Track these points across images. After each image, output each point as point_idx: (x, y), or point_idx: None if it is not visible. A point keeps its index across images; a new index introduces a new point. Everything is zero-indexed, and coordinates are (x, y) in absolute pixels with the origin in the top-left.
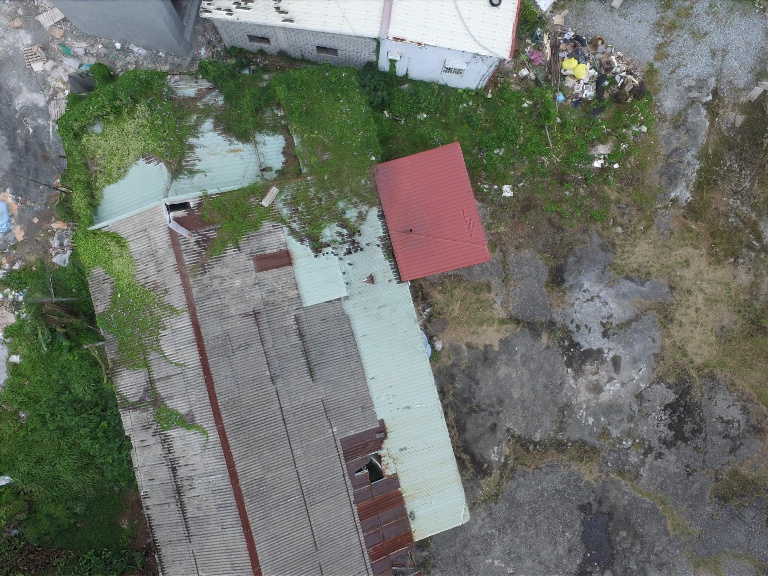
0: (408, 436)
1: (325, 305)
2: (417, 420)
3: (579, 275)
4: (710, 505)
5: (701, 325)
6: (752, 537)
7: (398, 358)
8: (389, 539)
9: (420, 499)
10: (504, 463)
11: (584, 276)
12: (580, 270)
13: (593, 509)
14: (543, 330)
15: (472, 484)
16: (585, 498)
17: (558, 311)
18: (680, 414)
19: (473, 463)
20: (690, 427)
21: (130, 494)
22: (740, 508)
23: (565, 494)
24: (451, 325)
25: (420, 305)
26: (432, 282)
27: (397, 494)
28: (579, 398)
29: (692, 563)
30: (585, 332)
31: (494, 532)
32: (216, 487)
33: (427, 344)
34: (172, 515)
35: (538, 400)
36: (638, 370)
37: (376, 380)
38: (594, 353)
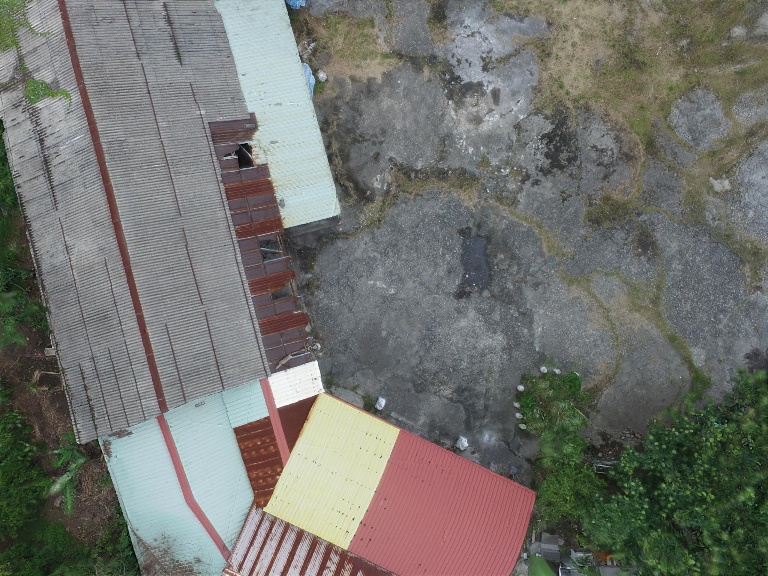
0: (279, 131)
1: (196, 0)
2: (289, 117)
3: (460, 12)
4: (584, 228)
5: (577, 58)
6: (624, 258)
7: (270, 58)
8: (258, 222)
9: (290, 190)
10: (386, 190)
11: (465, 13)
12: (461, 7)
13: (472, 233)
14: (425, 64)
15: (355, 210)
16: (464, 223)
17: (439, 45)
18: (556, 143)
19: (356, 190)
20: (566, 155)
21: (19, 220)
22: (613, 231)
23: (445, 219)
24: (335, 59)
25: (305, 39)
26: (317, 18)
27: (267, 183)
28: (459, 128)
29: (566, 282)
30: (465, 66)
31: (376, 255)
32: (79, 148)
33: (311, 75)
34: (41, 188)
35: (419, 130)
36: (516, 101)
37: (248, 76)
38: (474, 86)
